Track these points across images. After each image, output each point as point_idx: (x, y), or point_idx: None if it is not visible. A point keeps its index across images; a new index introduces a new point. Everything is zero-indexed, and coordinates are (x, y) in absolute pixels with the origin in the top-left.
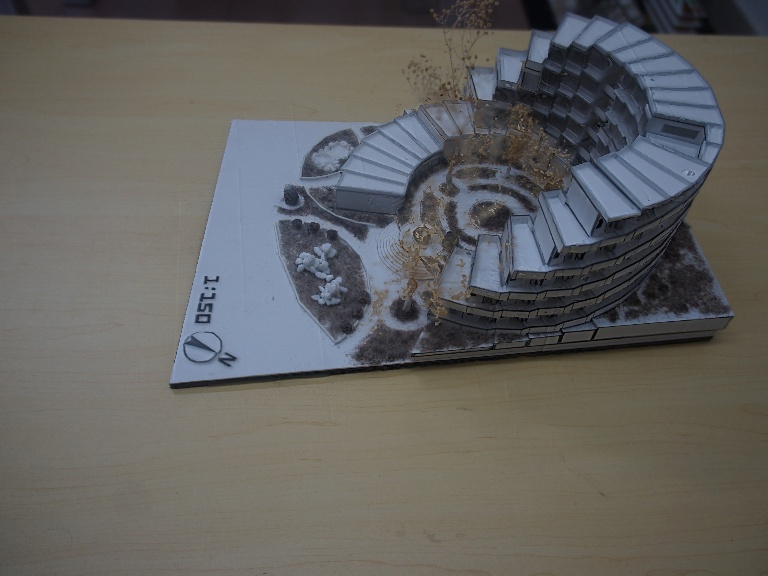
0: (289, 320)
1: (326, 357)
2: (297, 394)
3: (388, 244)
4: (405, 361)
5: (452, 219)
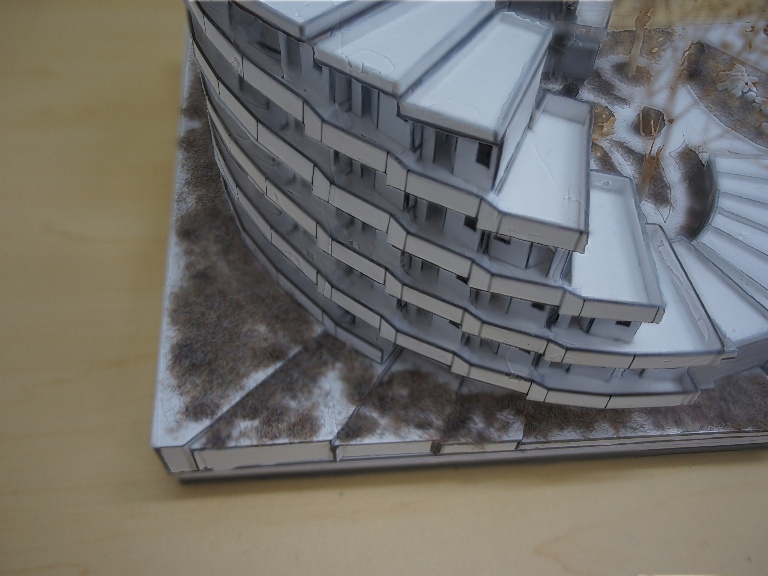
0: (767, 63)
1: (702, 34)
2: (712, 23)
3: (693, 134)
4: (612, 31)
5: (606, 161)
